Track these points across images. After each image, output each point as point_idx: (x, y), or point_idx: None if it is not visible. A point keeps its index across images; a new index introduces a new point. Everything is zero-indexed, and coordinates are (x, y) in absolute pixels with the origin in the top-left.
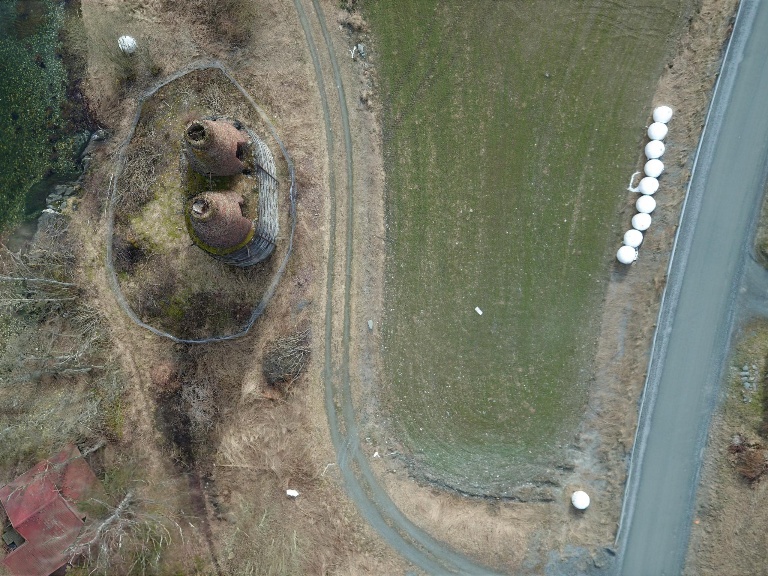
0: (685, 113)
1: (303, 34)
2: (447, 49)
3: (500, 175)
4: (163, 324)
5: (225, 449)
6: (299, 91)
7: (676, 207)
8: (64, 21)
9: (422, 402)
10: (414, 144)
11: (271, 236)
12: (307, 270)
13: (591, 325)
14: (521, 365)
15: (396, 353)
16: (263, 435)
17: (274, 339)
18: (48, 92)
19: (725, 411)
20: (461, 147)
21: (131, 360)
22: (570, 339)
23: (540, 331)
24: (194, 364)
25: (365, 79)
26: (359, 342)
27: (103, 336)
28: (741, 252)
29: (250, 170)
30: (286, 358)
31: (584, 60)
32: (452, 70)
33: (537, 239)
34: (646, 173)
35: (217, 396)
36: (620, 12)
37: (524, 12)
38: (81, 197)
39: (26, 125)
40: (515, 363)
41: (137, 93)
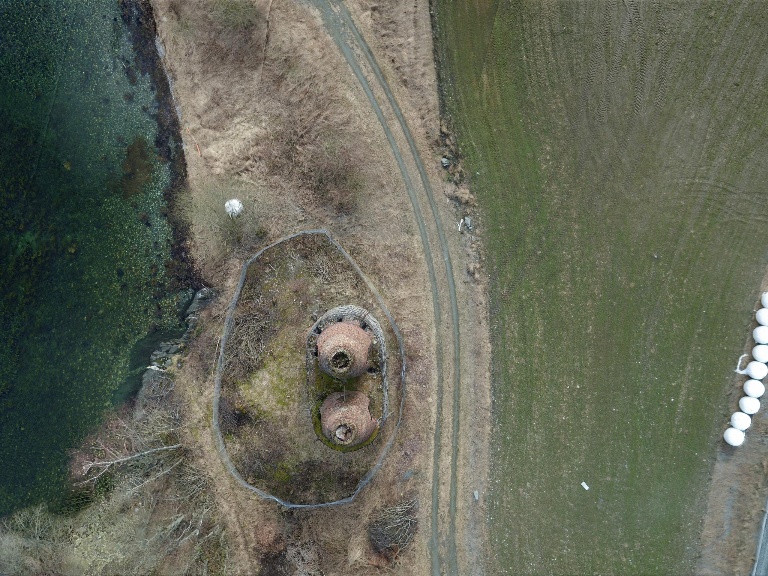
0: None
1: (411, 206)
2: (555, 226)
3: (607, 353)
4: (268, 486)
5: None
6: (407, 263)
7: None
8: (169, 181)
9: (528, 574)
10: (521, 318)
11: None
12: (414, 441)
13: (697, 503)
14: (627, 540)
15: (502, 524)
16: None
17: (380, 507)
18: (153, 250)
19: None
20: (568, 324)
21: (236, 520)
22: (676, 516)
23: (646, 508)
24: (299, 526)
25: (472, 252)
26: (465, 512)
27: (209, 497)
28: None
29: (375, 369)
30: (393, 528)
31: (693, 243)
32: (560, 247)
33: (644, 417)
34: (754, 357)
35: (322, 559)
36: (729, 197)
37: (633, 193)
38: (186, 356)
39: (131, 282)
40: (621, 538)
41: (242, 254)
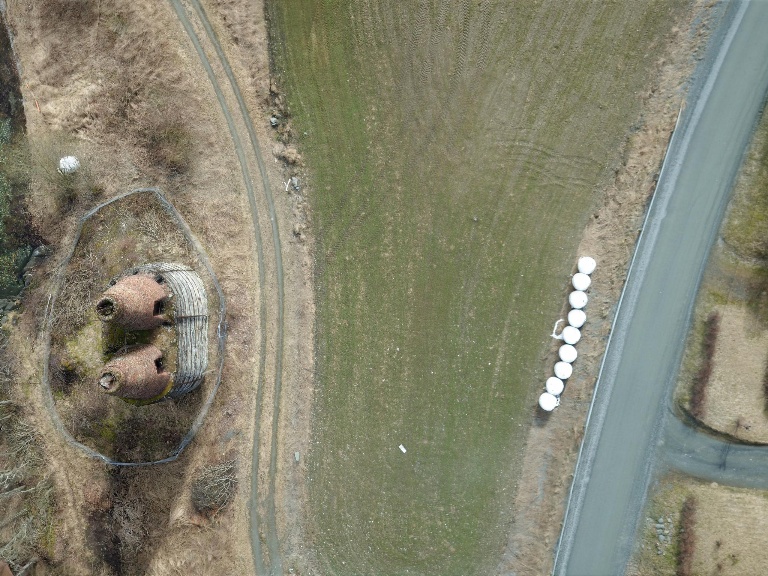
0: (609, 265)
1: (239, 165)
2: (379, 187)
3: (427, 315)
4: (96, 444)
5: (153, 572)
6: (233, 222)
7: (597, 358)
8: (9, 137)
9: (345, 536)
10: (344, 280)
11: (197, 375)
12: (236, 400)
13: (512, 468)
14: (443, 504)
15: (321, 486)
16: (190, 560)
17: (203, 466)
18: None
19: (640, 562)
20: (390, 286)
21: (65, 477)
22: (491, 481)
23: (462, 471)
24: (125, 485)
25: (298, 212)
26: (285, 473)
27: (37, 454)
28: (660, 405)
29: (170, 323)
30: (213, 487)
31: (512, 206)
32: (383, 209)
33: (461, 381)
34: (569, 322)
35: (147, 518)
36: (548, 160)
37: (454, 155)
38: (21, 312)
39: None
40: (437, 502)
41: (78, 211)
